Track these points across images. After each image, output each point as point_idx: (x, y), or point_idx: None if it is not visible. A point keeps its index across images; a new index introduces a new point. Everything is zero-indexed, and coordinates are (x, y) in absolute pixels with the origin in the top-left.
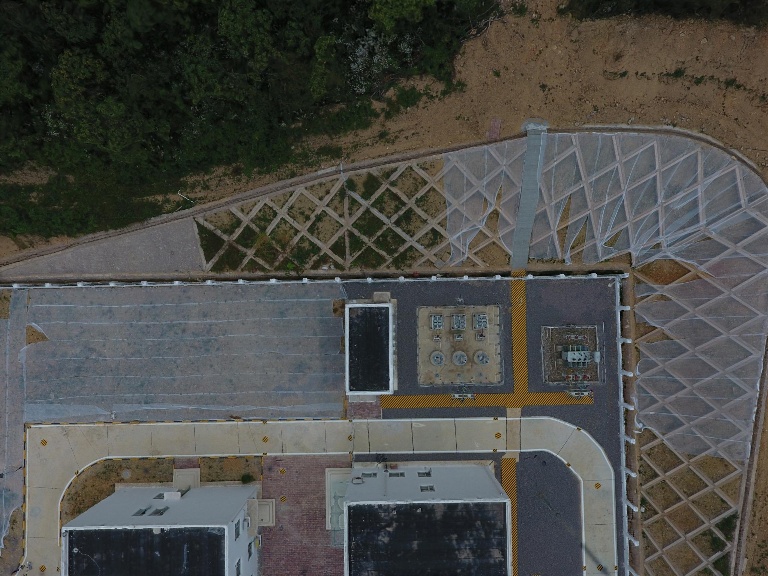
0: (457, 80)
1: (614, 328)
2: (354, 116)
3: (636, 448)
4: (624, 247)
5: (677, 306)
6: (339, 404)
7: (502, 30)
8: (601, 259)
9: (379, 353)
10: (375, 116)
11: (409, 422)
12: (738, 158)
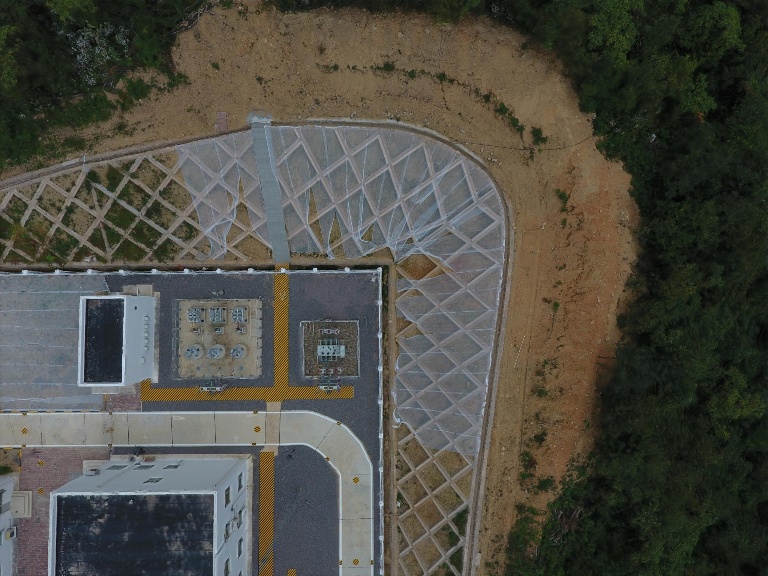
0: (177, 72)
1: (376, 323)
2: (91, 108)
3: (394, 443)
4: (382, 242)
5: (427, 301)
6: (99, 396)
7: (212, 22)
8: (363, 254)
9: (117, 345)
10: (113, 108)
11: (169, 415)
12: (464, 153)
